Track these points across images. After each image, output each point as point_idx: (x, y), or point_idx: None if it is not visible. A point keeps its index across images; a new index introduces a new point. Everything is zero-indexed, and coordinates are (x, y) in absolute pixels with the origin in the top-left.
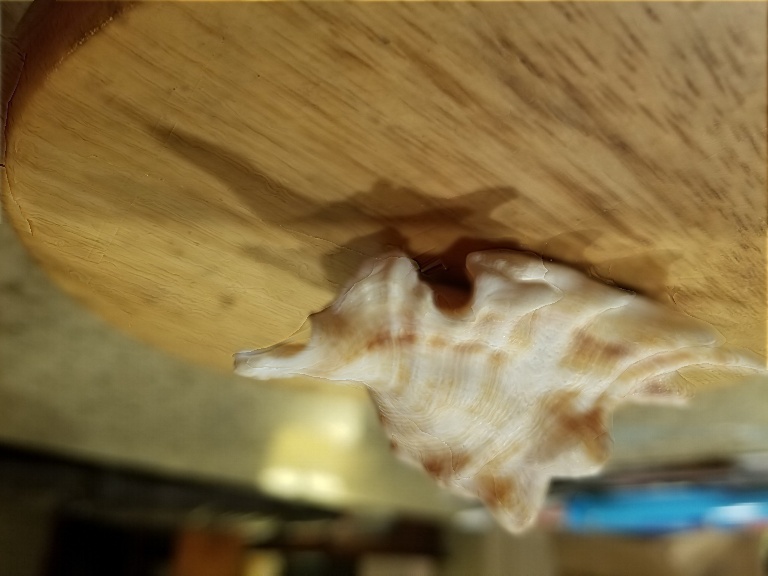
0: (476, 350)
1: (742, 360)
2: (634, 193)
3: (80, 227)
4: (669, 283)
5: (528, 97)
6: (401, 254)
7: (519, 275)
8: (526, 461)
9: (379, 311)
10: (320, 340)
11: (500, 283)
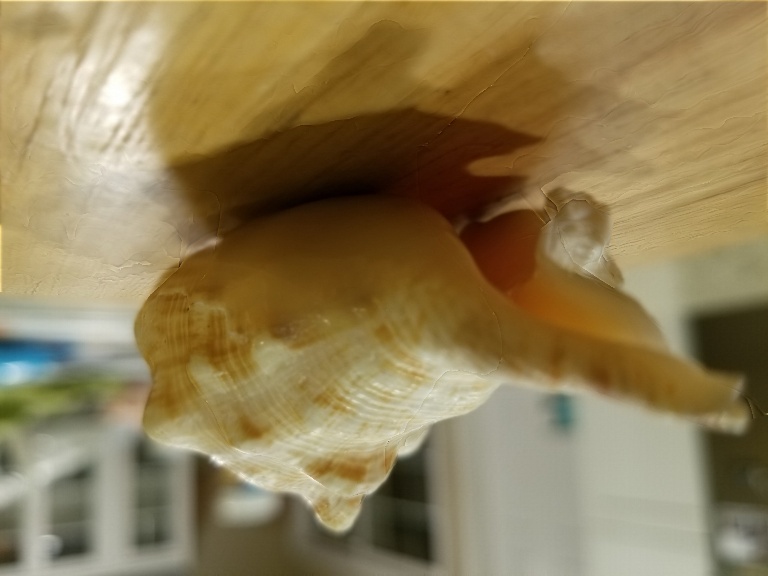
0: None
1: None
2: None
3: None
4: None
5: None
6: (472, 161)
7: None
8: None
9: None
10: None
11: None
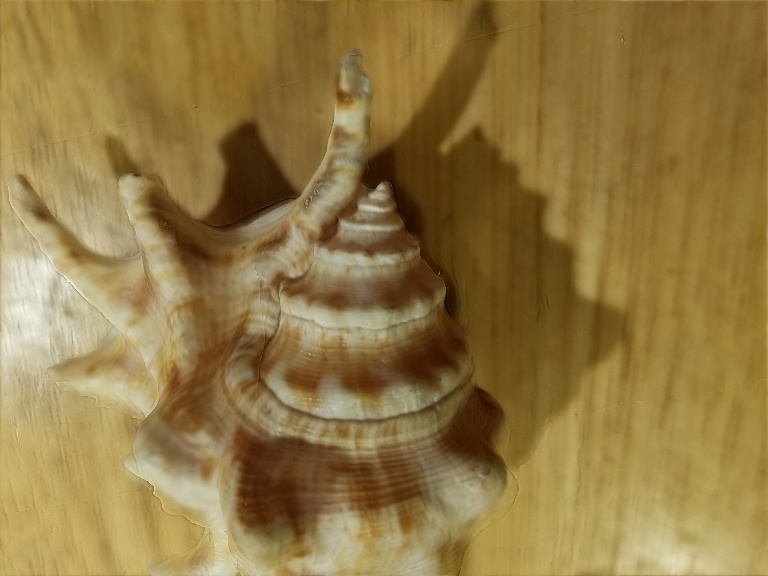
0: None
1: (50, 259)
2: (122, 496)
3: None
4: None
5: None
6: None
7: None
8: None
9: None
10: None
11: None
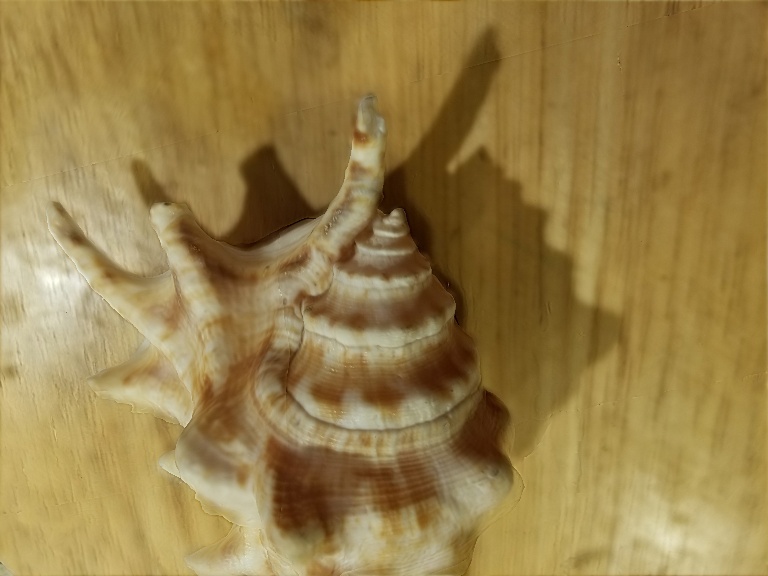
0: None
1: (87, 279)
2: (154, 490)
3: None
4: None
5: None
6: None
7: None
8: None
9: None
10: None
11: None
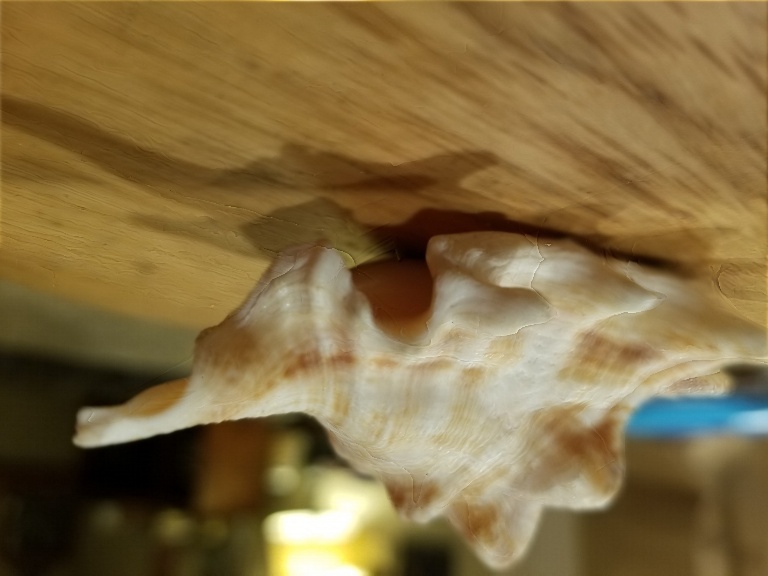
0: (440, 366)
1: None
2: (674, 162)
3: None
4: (714, 264)
5: (494, 24)
6: (347, 227)
7: (497, 276)
8: (509, 489)
9: (302, 321)
10: (202, 380)
11: (469, 289)
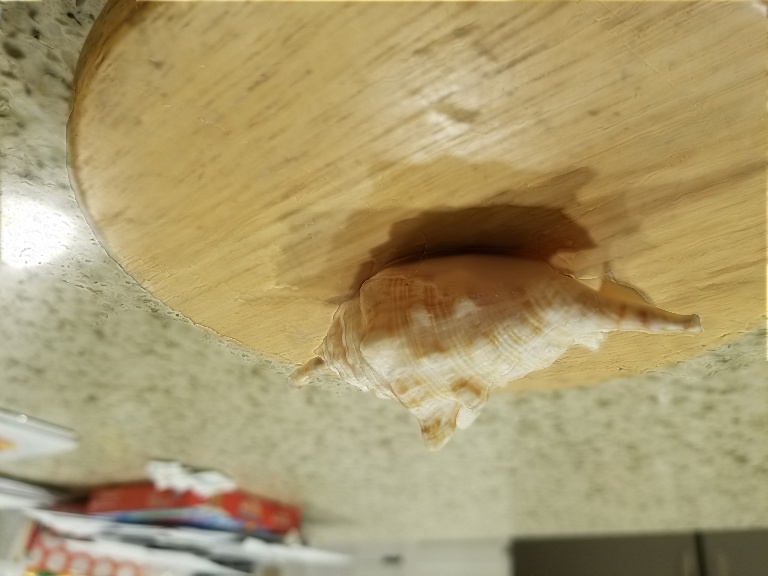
0: None
1: None
2: None
3: (676, 35)
4: None
5: None
6: (560, 248)
7: None
8: (466, 408)
9: None
10: None
11: None
